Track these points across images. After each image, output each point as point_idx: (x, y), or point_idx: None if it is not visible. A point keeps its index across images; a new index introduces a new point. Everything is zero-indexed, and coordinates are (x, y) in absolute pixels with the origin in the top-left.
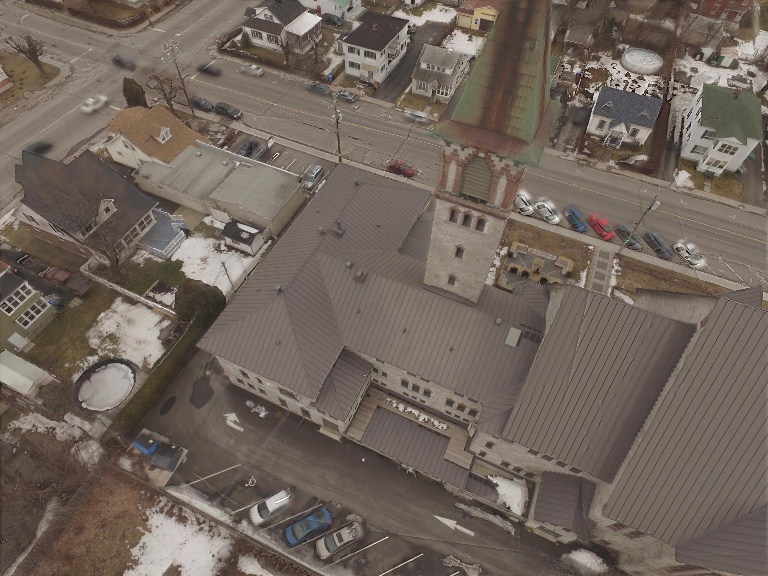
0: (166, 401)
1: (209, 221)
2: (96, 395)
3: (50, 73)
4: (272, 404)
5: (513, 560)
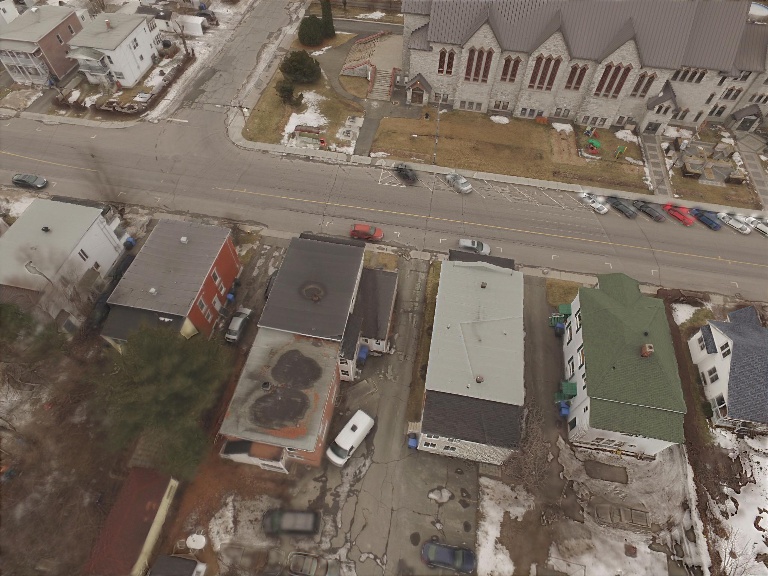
0: None
1: None
2: None
3: None
4: None
5: None
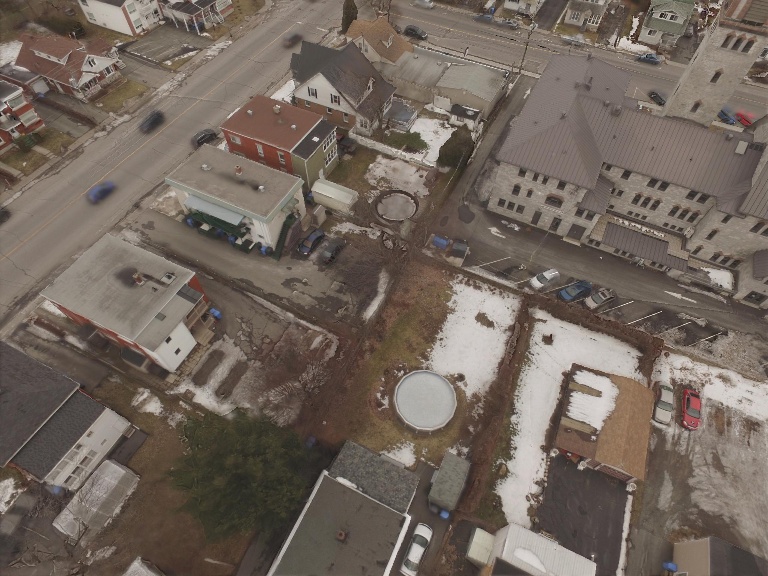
0: (442, 218)
1: (430, 107)
2: (391, 212)
3: (259, 2)
4: (522, 223)
5: (729, 317)
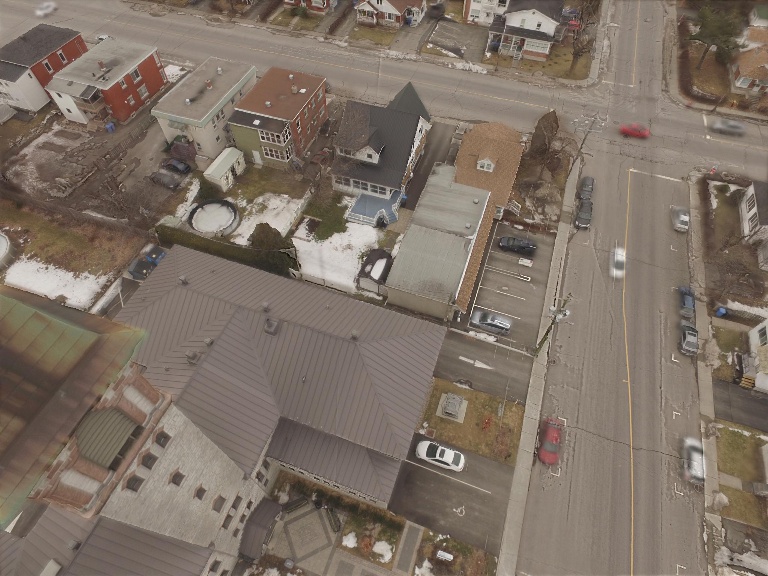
0: None
1: (400, 239)
2: (207, 214)
3: (576, 74)
4: None
5: None
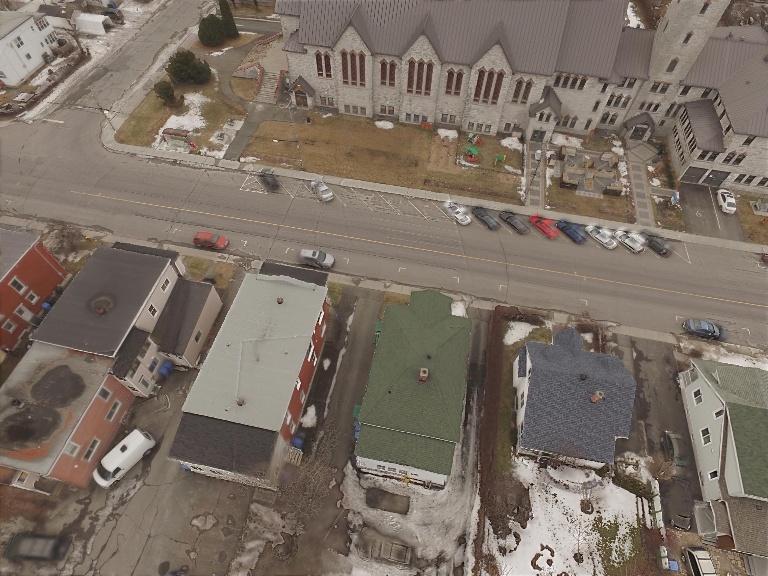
0: None
1: None
2: None
3: None
4: None
5: None
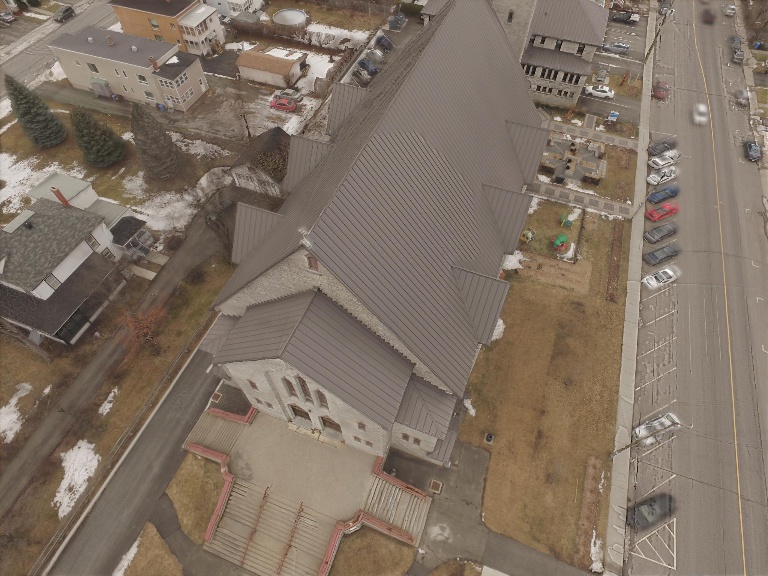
0: None
1: None
2: (422, 3)
3: None
4: None
5: None
